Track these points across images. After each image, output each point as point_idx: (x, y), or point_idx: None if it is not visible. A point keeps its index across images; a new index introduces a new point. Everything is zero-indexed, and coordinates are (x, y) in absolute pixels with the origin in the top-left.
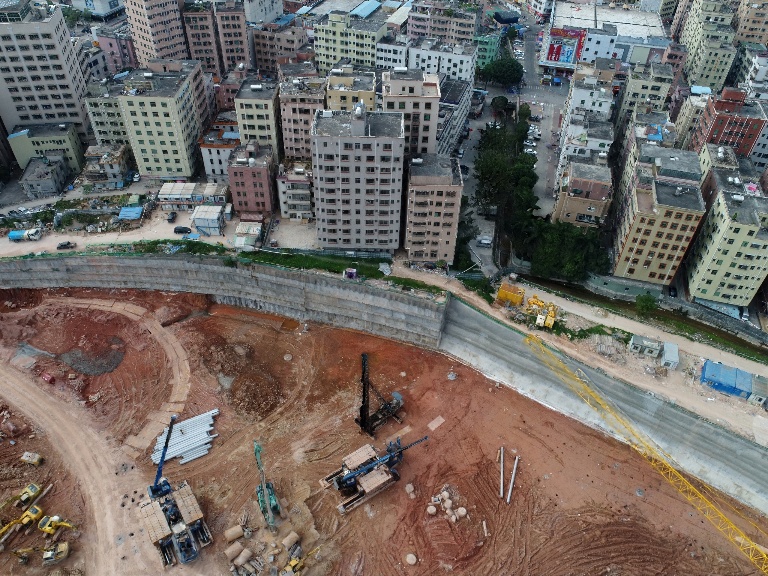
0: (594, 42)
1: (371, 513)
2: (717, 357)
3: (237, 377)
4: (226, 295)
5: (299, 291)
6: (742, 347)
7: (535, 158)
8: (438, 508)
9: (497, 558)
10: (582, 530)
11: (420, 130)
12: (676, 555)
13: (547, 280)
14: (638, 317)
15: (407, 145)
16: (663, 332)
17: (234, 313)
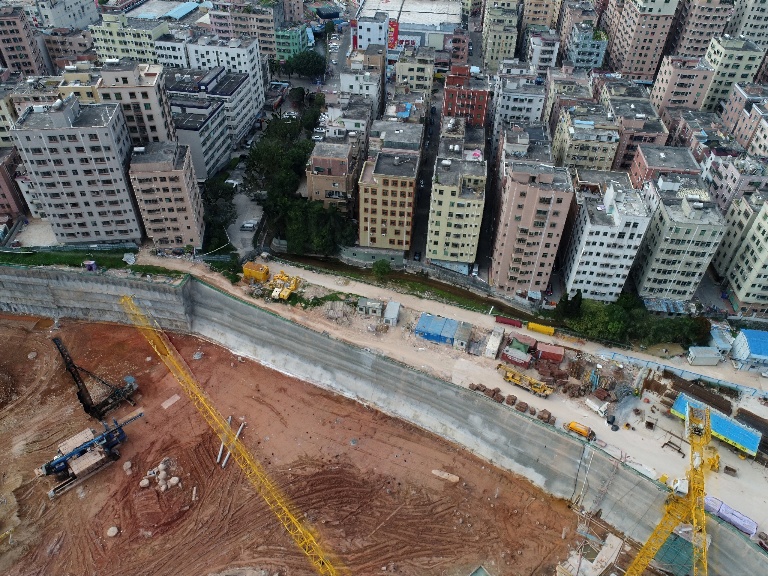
0: (365, 30)
1: (82, 494)
2: (440, 311)
3: None
4: None
5: (45, 289)
6: (469, 300)
7: (313, 143)
8: (152, 480)
9: (200, 519)
10: (289, 483)
11: (145, 120)
12: (373, 493)
13: (305, 256)
14: (377, 282)
15: (137, 135)
16: (396, 293)
17: None
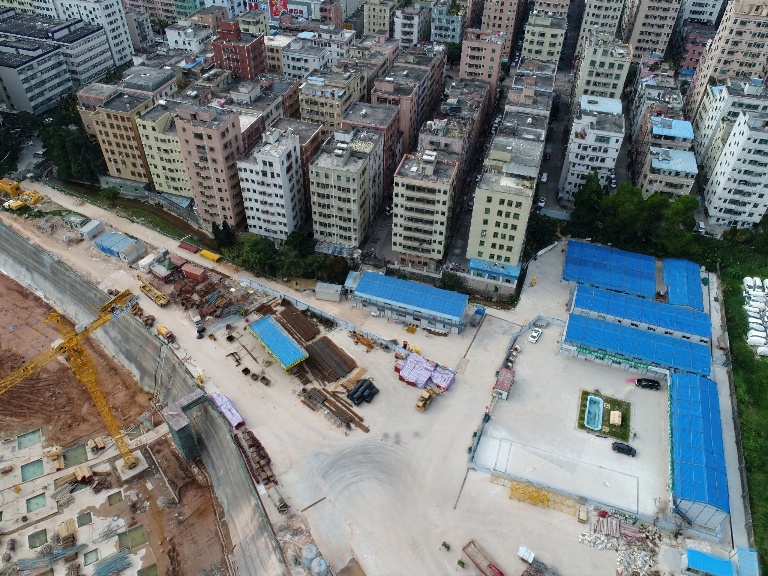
0: None
1: None
2: (139, 233)
3: None
4: None
5: None
6: None
7: None
8: None
9: None
10: None
11: None
12: None
13: (75, 183)
14: (108, 206)
15: None
16: (116, 216)
17: None
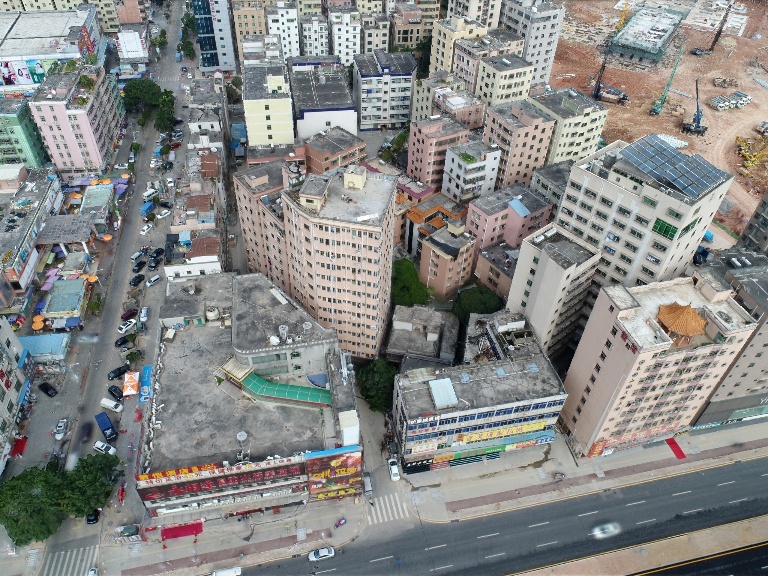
0: None
1: None
2: None
3: None
4: None
5: None
6: None
7: None
8: None
9: None
10: None
11: None
12: None
13: None
14: None
15: None
16: None
17: None
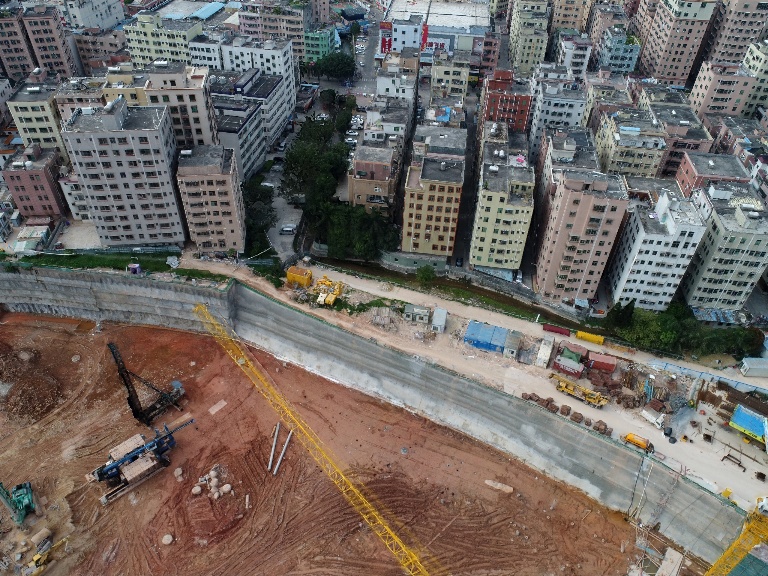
0: (400, 32)
1: (134, 500)
2: (486, 318)
3: (16, 383)
4: (17, 302)
5: (88, 291)
6: (514, 307)
7: (348, 146)
8: (204, 488)
9: (254, 528)
10: None
11: (191, 122)
12: (427, 504)
13: (346, 261)
14: (421, 288)
15: (182, 138)
16: (441, 300)
17: (28, 320)
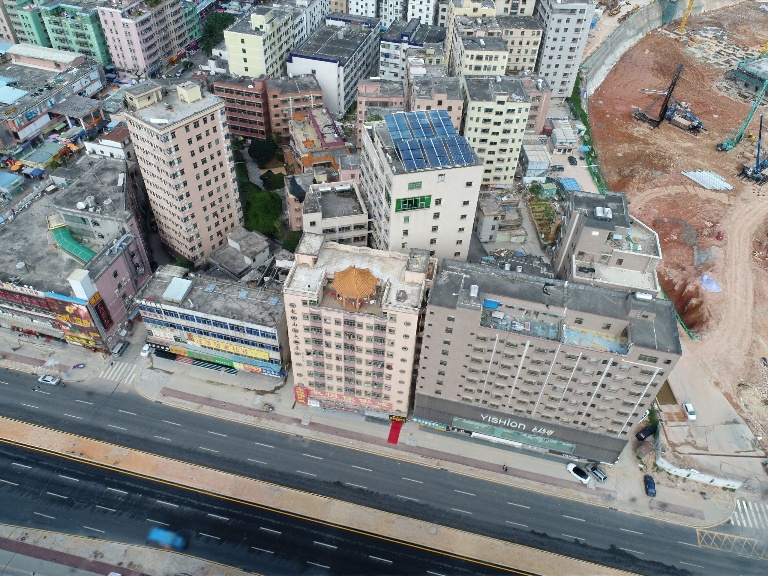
0: None
1: None
2: None
3: (651, 169)
4: None
5: None
6: None
7: None
8: None
9: (697, 98)
10: None
11: None
12: None
13: None
14: None
15: None
16: None
17: None
